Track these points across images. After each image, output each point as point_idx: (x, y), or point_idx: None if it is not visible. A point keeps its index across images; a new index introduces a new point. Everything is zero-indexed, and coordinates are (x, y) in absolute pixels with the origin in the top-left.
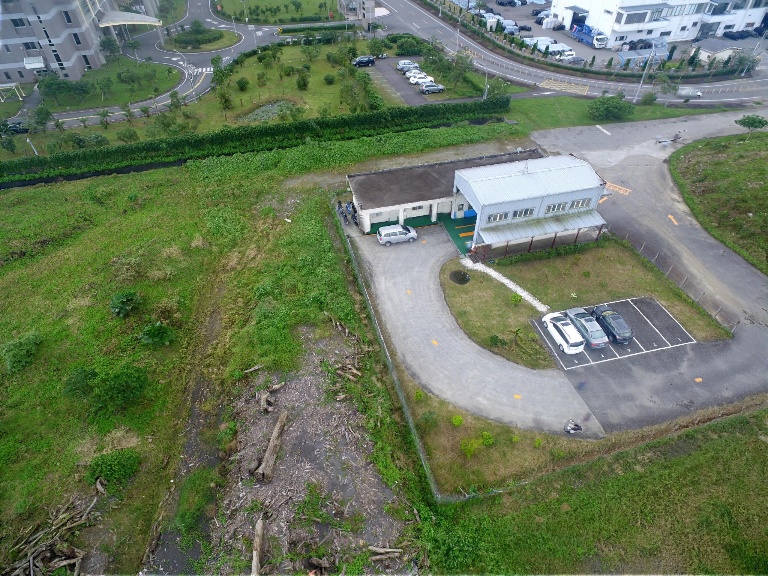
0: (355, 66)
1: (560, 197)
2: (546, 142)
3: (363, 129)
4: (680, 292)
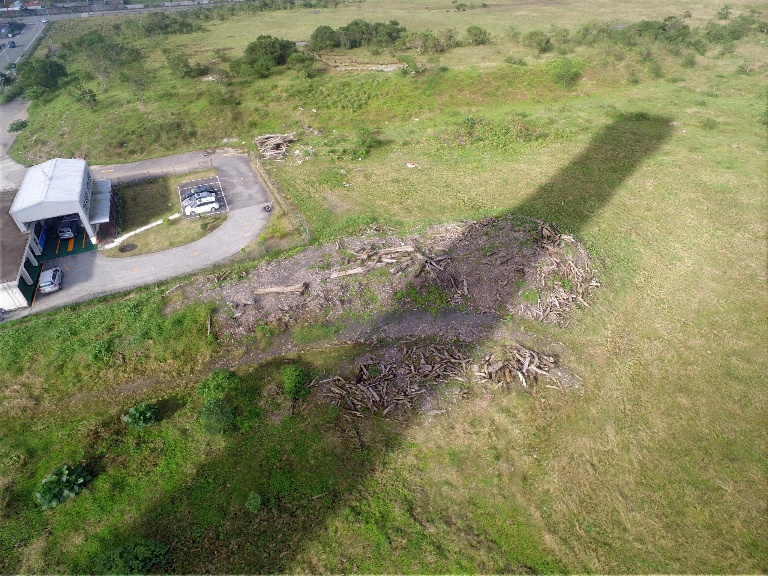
0: None
1: (84, 177)
2: None
3: None
4: (180, 175)
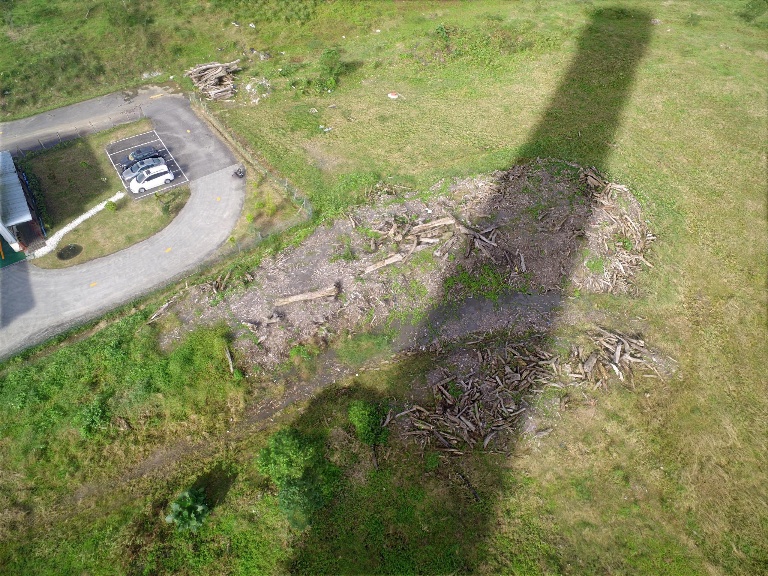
0: None
1: None
2: None
3: None
4: (102, 133)
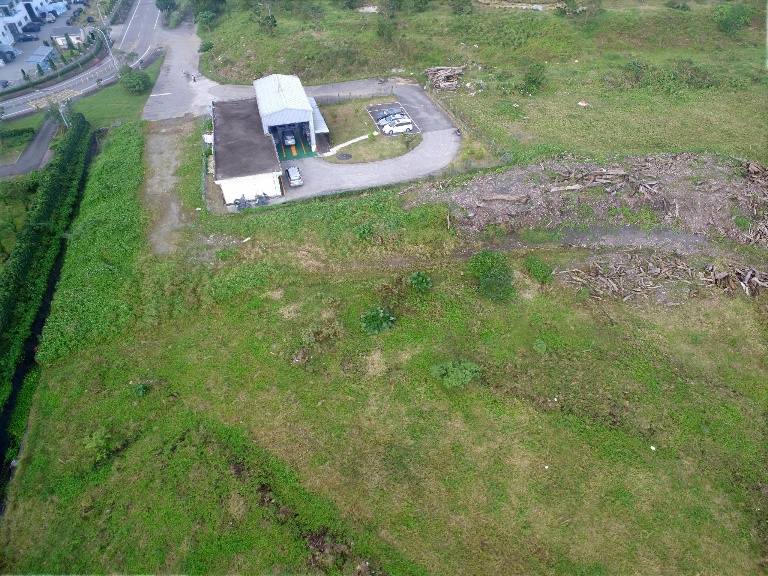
0: None
1: None
2: (166, 115)
3: (62, 202)
4: (364, 99)
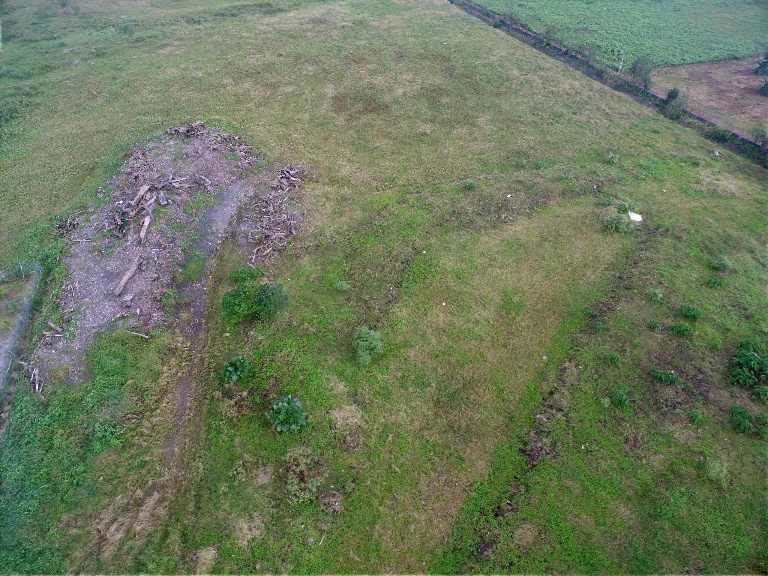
0: None
1: None
2: None
3: None
4: None
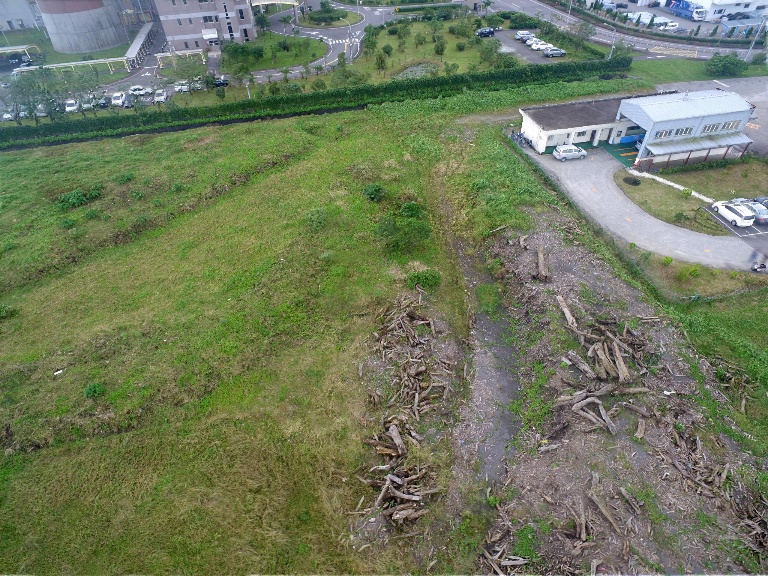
0: (478, 36)
1: (716, 118)
2: None
3: (506, 83)
4: None
